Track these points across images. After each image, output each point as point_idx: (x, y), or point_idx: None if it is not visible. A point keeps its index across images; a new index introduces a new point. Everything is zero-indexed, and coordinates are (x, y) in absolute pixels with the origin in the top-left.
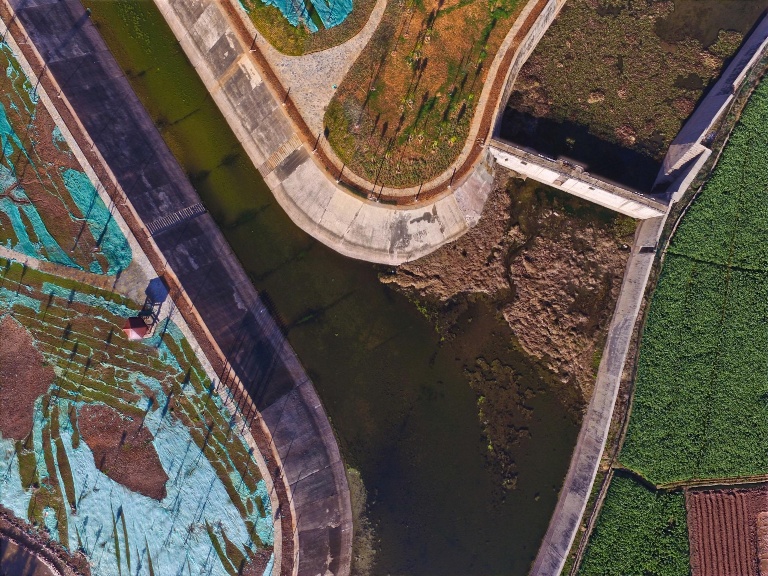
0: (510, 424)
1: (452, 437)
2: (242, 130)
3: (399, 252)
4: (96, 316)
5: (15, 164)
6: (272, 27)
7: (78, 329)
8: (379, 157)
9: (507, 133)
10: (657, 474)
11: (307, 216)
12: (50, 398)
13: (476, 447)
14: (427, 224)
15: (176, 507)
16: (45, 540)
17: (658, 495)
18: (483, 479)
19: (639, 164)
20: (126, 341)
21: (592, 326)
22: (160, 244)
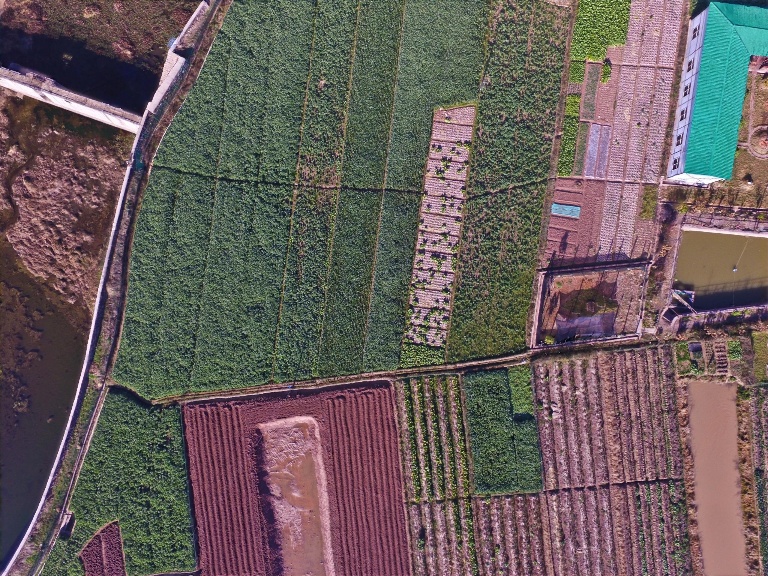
0: (20, 347)
1: None
2: None
3: None
4: None
5: None
6: None
7: None
8: None
9: None
10: (149, 389)
11: None
12: None
13: None
14: None
15: None
16: None
17: (153, 410)
18: None
19: (139, 79)
20: None
21: (98, 245)
22: None
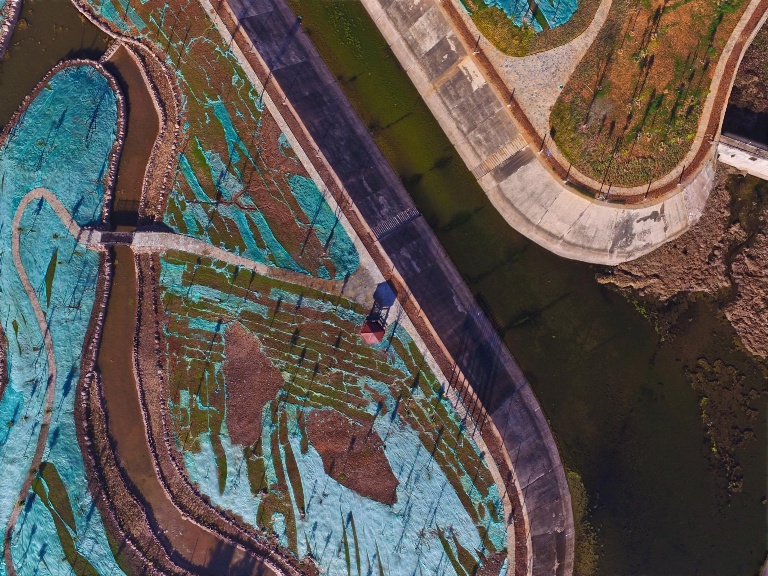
0: (734, 426)
1: (674, 439)
2: (456, 132)
3: (619, 252)
4: (324, 321)
5: (242, 171)
6: (496, 28)
7: (306, 334)
8: (607, 156)
9: (726, 129)
10: None
11: (525, 217)
12: (278, 403)
13: (699, 449)
14: (653, 223)
15: (407, 512)
16: (273, 546)
17: None
18: (706, 482)
19: None
20: (354, 346)
21: None
22: (386, 248)
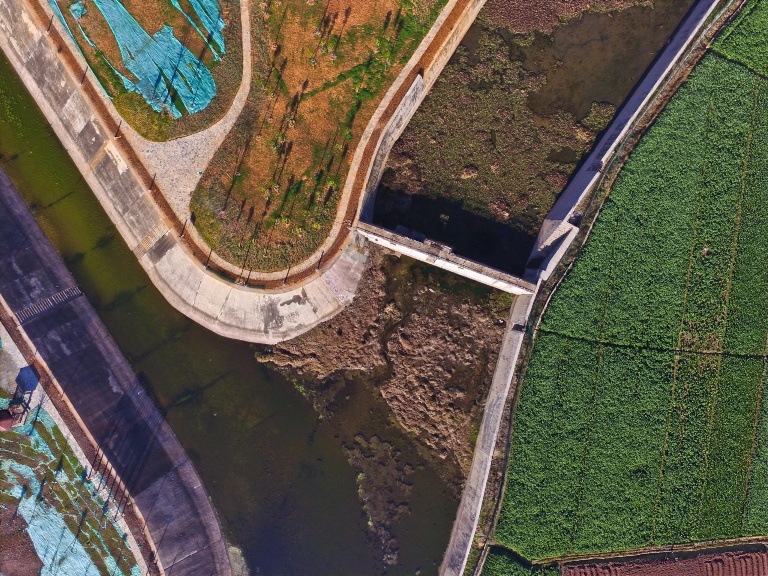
0: (390, 500)
1: (332, 514)
2: (115, 213)
3: (274, 332)
4: None
5: None
6: (136, 113)
7: None
8: (246, 242)
9: (380, 211)
10: (531, 550)
11: (181, 298)
12: None
13: (356, 523)
14: (298, 306)
15: None
16: None
17: (533, 570)
18: (364, 554)
19: (514, 239)
20: None
21: (469, 401)
22: (30, 332)
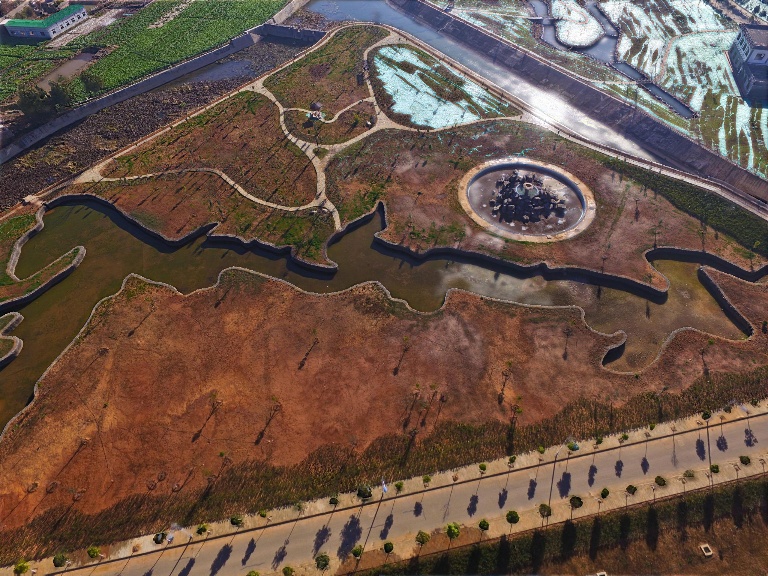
0: None
1: (348, 4)
2: None
3: None
4: (469, 7)
5: None
6: None
7: None
8: None
9: None
10: None
11: None
12: None
13: None
14: None
15: None
16: None
17: None
18: None
19: None
20: None
21: None
22: None
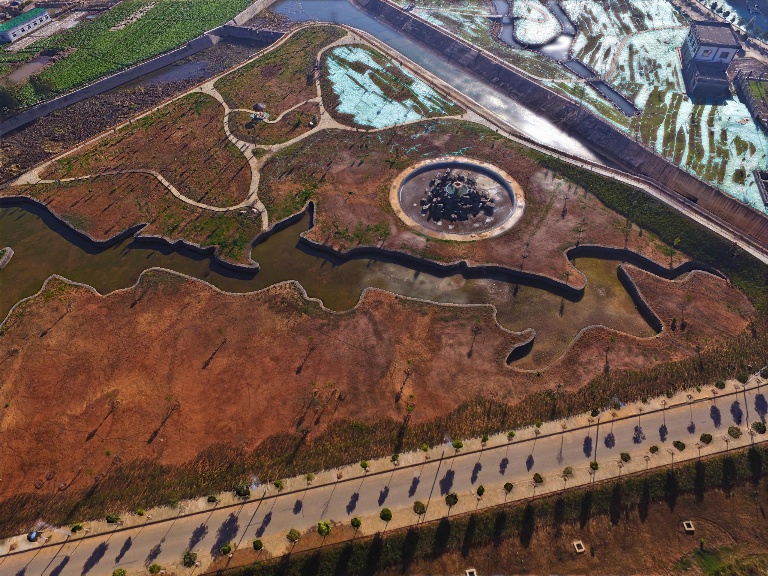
0: None
1: None
2: None
3: None
4: None
5: None
6: None
7: (436, 5)
8: None
9: None
10: None
11: None
12: None
13: None
14: None
15: None
16: None
17: None
18: None
19: None
20: None
21: None
22: None
